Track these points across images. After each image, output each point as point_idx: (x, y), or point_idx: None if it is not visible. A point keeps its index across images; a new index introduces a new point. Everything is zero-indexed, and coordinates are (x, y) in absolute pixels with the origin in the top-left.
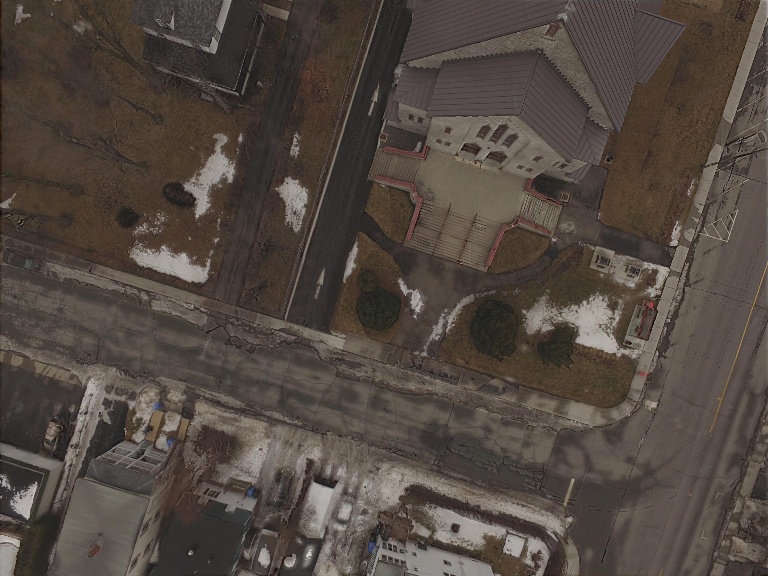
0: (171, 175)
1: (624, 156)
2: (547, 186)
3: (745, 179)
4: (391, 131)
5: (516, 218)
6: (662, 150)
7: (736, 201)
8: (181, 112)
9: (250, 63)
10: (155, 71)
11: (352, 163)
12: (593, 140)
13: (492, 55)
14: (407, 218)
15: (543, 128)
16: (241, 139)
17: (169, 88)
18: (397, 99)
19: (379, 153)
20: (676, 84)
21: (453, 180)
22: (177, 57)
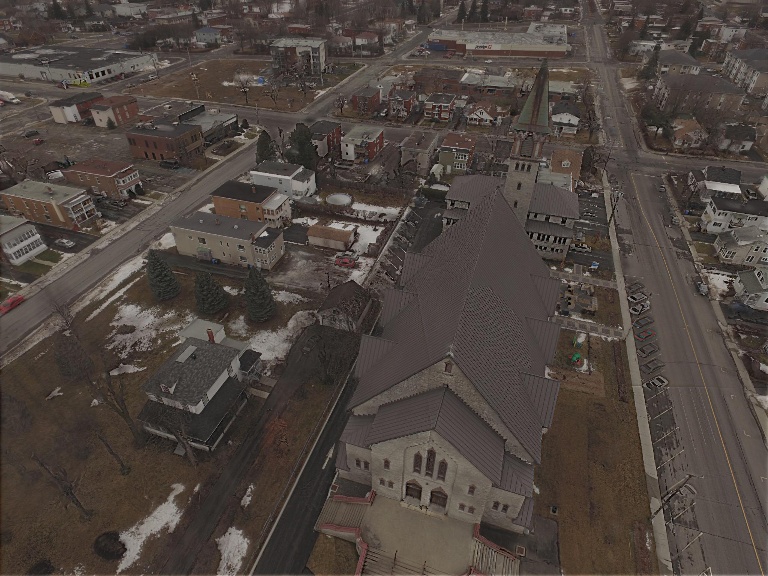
0: (112, 524)
1: (568, 508)
2: (499, 538)
3: (699, 532)
4: (342, 482)
5: (468, 568)
6: (603, 502)
7: (702, 557)
8: (150, 464)
9: (227, 426)
10: (143, 432)
11: (300, 513)
12: (519, 473)
13: (414, 395)
14: (352, 574)
15: (461, 445)
16: (197, 489)
17: (149, 445)
18: (343, 439)
19: (328, 502)
20: (592, 446)
21: (399, 526)
22: (166, 417)
